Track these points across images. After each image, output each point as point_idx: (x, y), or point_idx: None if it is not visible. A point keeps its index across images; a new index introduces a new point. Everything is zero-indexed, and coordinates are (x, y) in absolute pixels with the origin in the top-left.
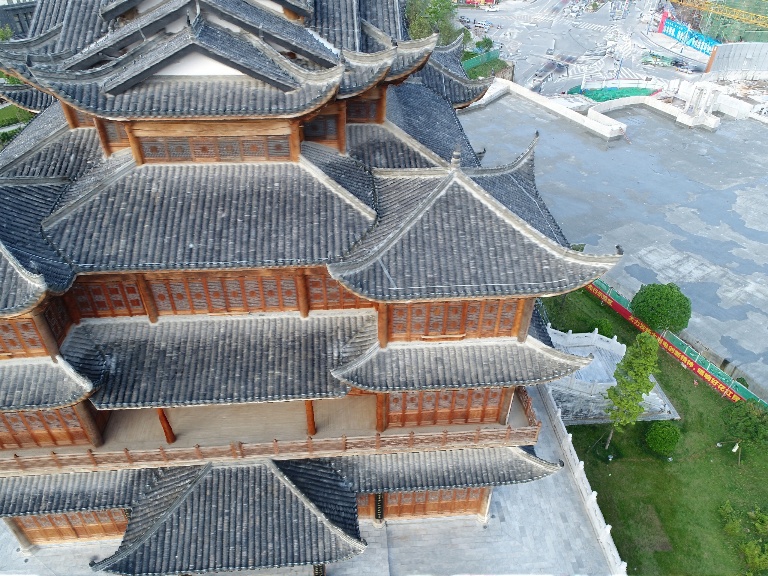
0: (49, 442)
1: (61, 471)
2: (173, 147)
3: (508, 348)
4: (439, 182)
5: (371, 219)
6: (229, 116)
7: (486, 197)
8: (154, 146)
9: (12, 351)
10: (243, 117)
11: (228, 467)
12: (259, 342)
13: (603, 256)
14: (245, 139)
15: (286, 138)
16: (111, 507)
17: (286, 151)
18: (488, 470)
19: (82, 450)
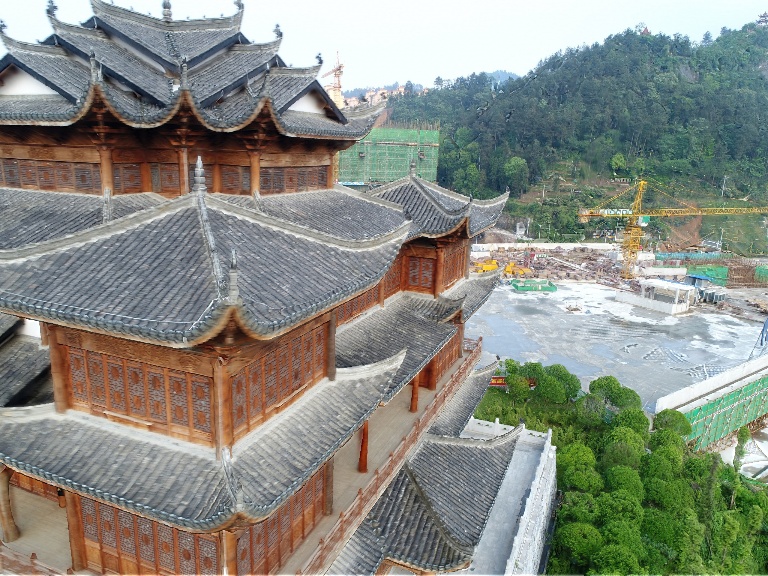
0: (299, 537)
1: (342, 545)
2: (276, 178)
3: (467, 284)
4: (409, 185)
5: (401, 211)
6: (338, 137)
7: (436, 187)
8: (266, 178)
9: (305, 382)
10: (342, 138)
11: (412, 458)
12: (387, 328)
13: (502, 196)
14: (310, 170)
15: (326, 169)
16: (376, 568)
17: (325, 180)
18: (473, 392)
19: (326, 524)
